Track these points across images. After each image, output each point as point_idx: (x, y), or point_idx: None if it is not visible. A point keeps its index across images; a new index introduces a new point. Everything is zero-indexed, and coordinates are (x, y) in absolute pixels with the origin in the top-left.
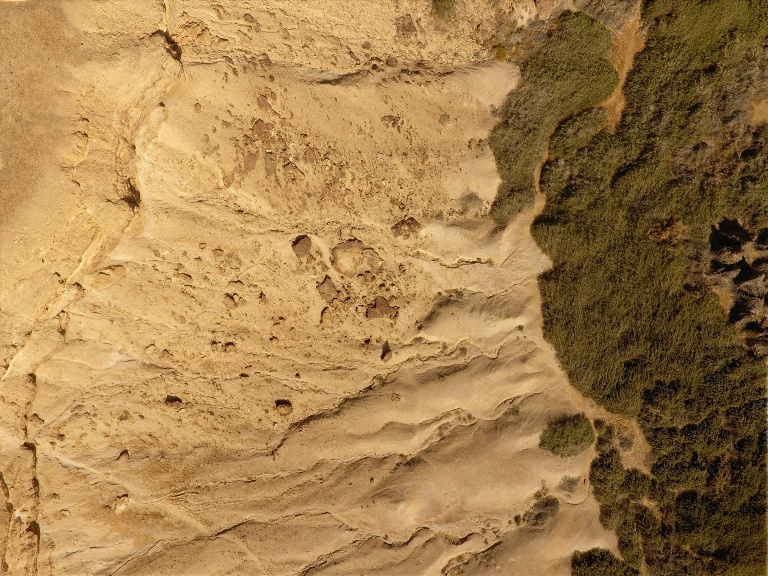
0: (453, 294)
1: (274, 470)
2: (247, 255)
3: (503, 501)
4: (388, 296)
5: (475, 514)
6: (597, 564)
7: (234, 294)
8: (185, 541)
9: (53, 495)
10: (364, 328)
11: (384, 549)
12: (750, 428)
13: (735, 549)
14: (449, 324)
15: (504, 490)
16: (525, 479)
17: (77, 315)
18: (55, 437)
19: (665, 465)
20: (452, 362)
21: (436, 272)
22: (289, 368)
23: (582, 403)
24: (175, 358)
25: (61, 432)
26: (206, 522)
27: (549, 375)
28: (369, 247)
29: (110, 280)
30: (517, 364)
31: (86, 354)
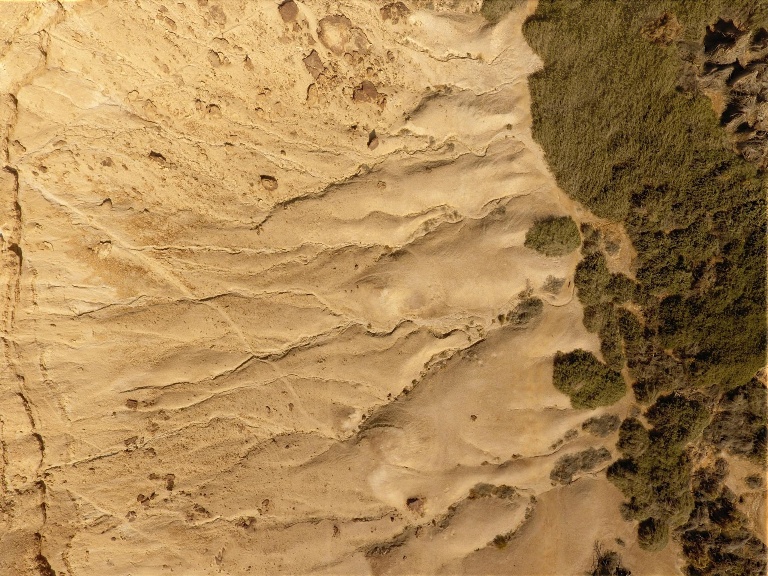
0: (442, 89)
1: (258, 245)
2: (232, 11)
3: (487, 299)
4: (376, 82)
5: (459, 311)
6: (579, 363)
7: (219, 52)
8: (168, 301)
9: (35, 224)
10: (351, 113)
11: (367, 336)
12: (737, 231)
13: (717, 351)
14: (437, 116)
15: (488, 286)
16: (510, 276)
17: (58, 39)
18: (37, 167)
19: (650, 269)
20: (439, 157)
21: (425, 64)
22: (274, 144)
23: (569, 206)
24: (159, 111)
25: (43, 164)
26: (189, 285)
27: (537, 176)
28: (357, 27)
29: (92, 7)
30: (505, 162)
31: (68, 86)
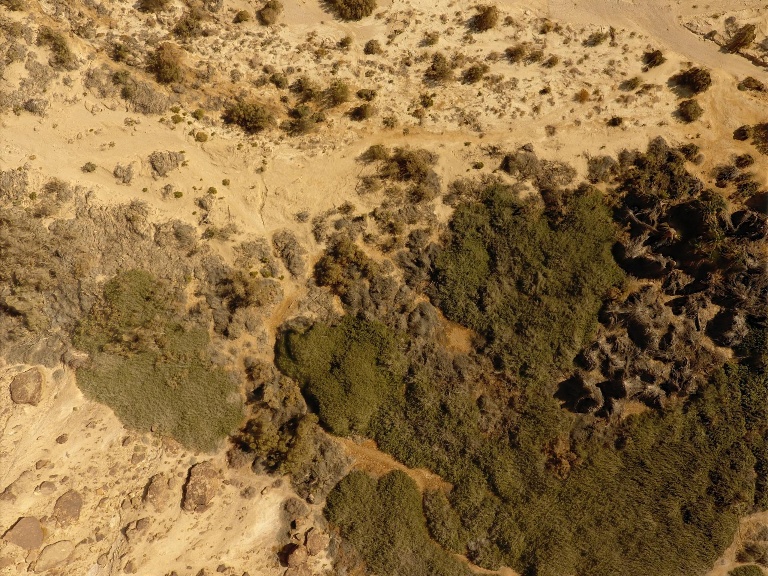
0: None
1: None
2: None
3: None
4: None
5: None
6: None
7: None
8: None
9: None
10: None
11: None
12: None
13: None
14: None
15: None
16: None
17: None
18: None
19: None
20: None
21: None
22: None
23: (718, 572)
24: None
25: None
26: None
27: None
28: None
29: None
30: None
31: None
